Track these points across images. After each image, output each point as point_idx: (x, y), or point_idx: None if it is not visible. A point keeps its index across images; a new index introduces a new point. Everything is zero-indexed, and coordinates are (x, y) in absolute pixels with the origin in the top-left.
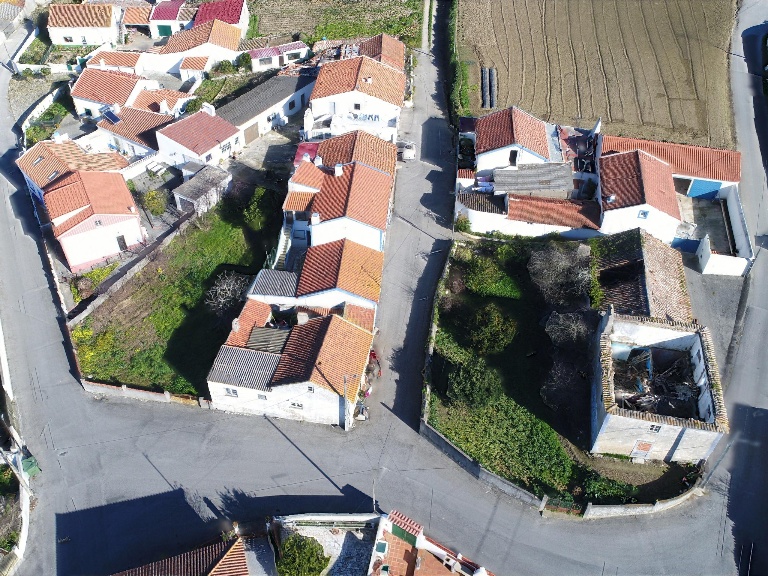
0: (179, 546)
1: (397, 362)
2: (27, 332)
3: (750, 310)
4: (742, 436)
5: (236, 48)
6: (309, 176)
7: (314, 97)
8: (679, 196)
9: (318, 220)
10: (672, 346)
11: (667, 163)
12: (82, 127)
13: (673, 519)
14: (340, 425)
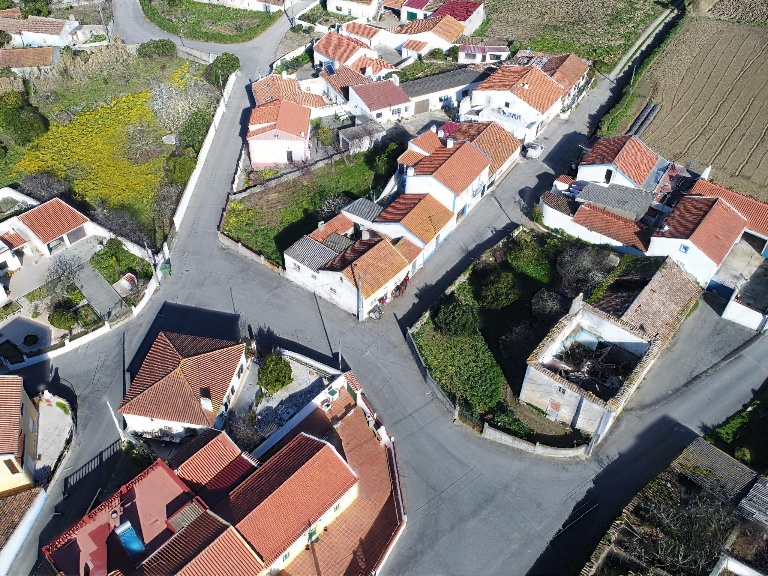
0: None
1: (423, 292)
2: (207, 195)
3: (741, 357)
4: (651, 437)
5: (452, 41)
6: (428, 142)
7: (477, 89)
8: (753, 253)
9: (412, 173)
10: (630, 349)
11: (747, 218)
12: (314, 74)
13: (548, 464)
14: (358, 316)
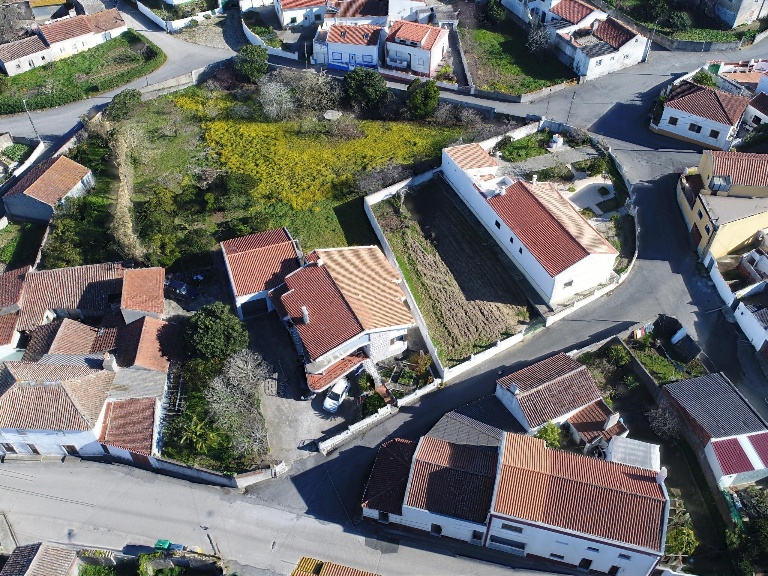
0: (645, 113)
1: None
2: None
3: None
4: None
5: None
6: None
7: None
8: None
9: None
10: None
11: None
12: (293, 32)
13: None
14: (642, 61)
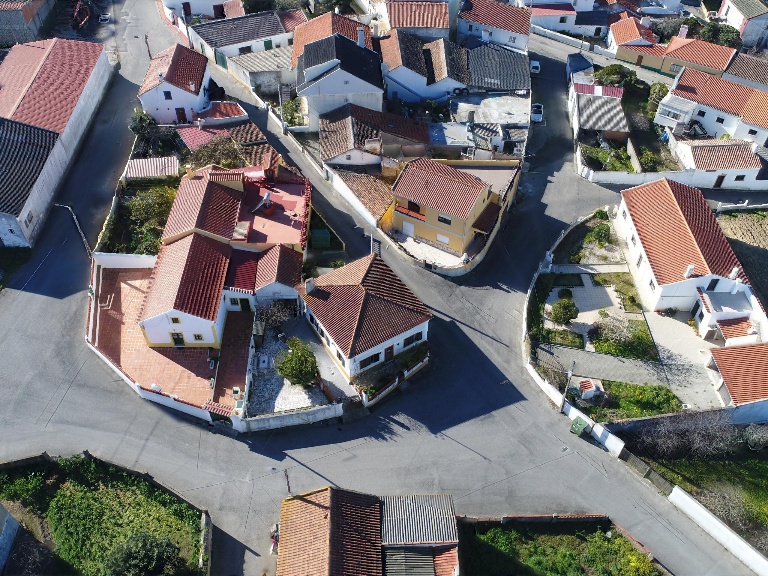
0: (411, 392)
1: None
2: None
3: None
4: None
5: None
6: None
7: None
8: None
9: None
10: None
11: None
12: None
13: None
14: None
